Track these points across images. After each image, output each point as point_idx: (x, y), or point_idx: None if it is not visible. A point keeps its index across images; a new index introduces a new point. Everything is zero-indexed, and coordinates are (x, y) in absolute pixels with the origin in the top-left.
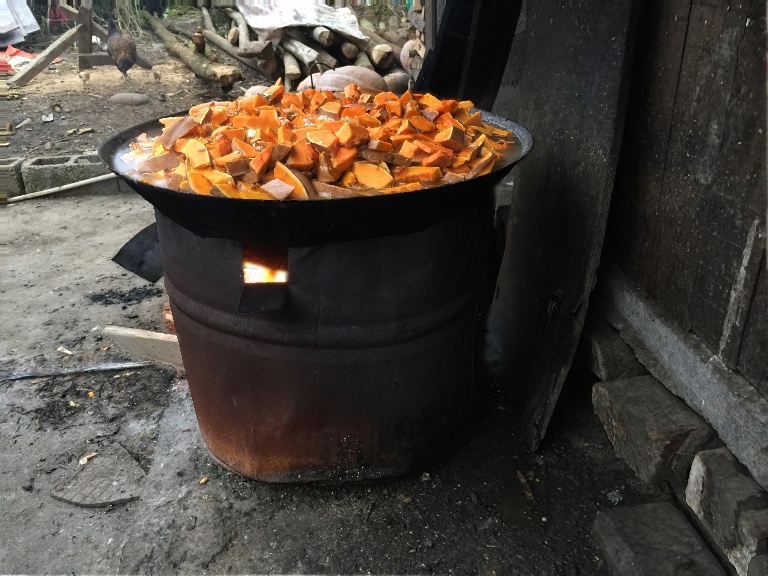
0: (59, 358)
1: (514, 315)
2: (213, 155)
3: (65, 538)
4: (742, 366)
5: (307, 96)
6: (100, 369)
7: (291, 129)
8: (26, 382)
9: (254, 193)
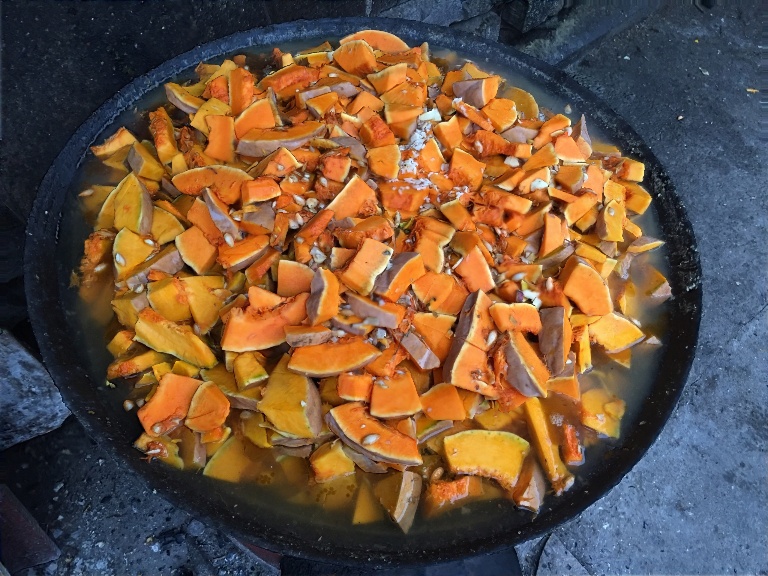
0: None
1: None
2: (595, 212)
3: (634, 575)
4: (385, 5)
5: (336, 222)
6: None
7: None
8: None
9: (605, 151)
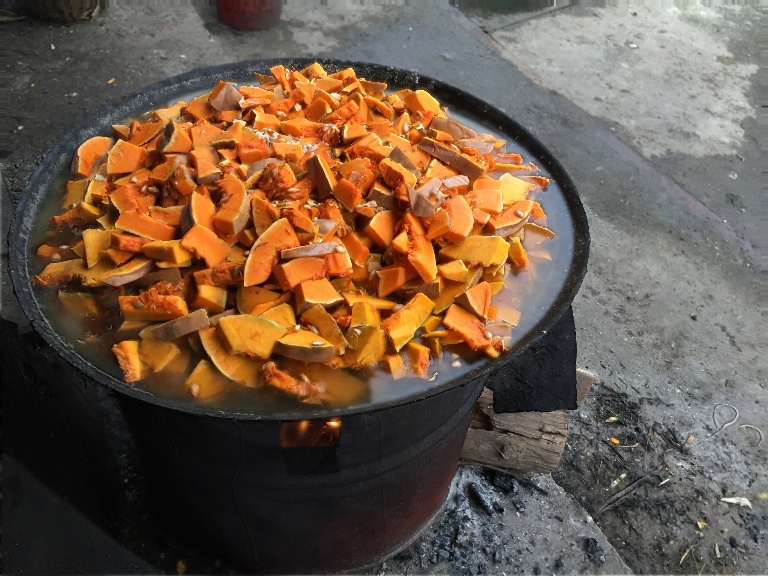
0: (725, 487)
1: (89, 518)
2: None
3: None
4: None
5: None
6: (649, 474)
7: (320, 134)
8: (700, 437)
9: None
